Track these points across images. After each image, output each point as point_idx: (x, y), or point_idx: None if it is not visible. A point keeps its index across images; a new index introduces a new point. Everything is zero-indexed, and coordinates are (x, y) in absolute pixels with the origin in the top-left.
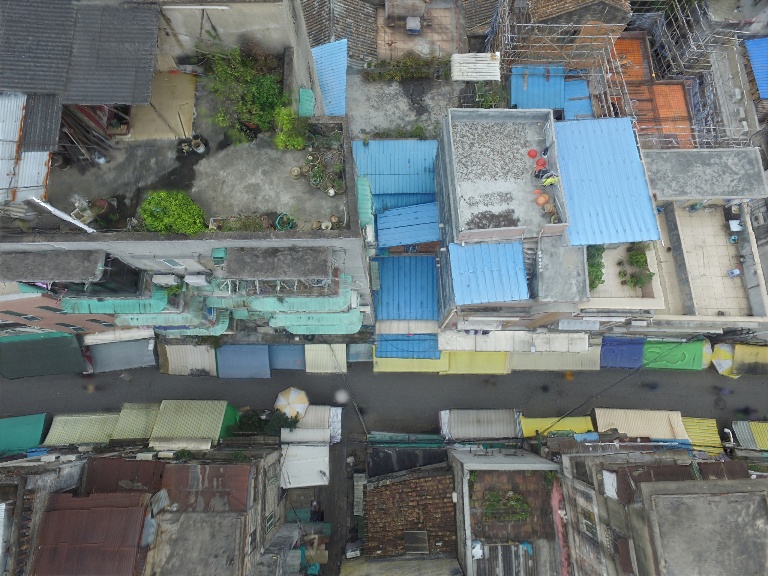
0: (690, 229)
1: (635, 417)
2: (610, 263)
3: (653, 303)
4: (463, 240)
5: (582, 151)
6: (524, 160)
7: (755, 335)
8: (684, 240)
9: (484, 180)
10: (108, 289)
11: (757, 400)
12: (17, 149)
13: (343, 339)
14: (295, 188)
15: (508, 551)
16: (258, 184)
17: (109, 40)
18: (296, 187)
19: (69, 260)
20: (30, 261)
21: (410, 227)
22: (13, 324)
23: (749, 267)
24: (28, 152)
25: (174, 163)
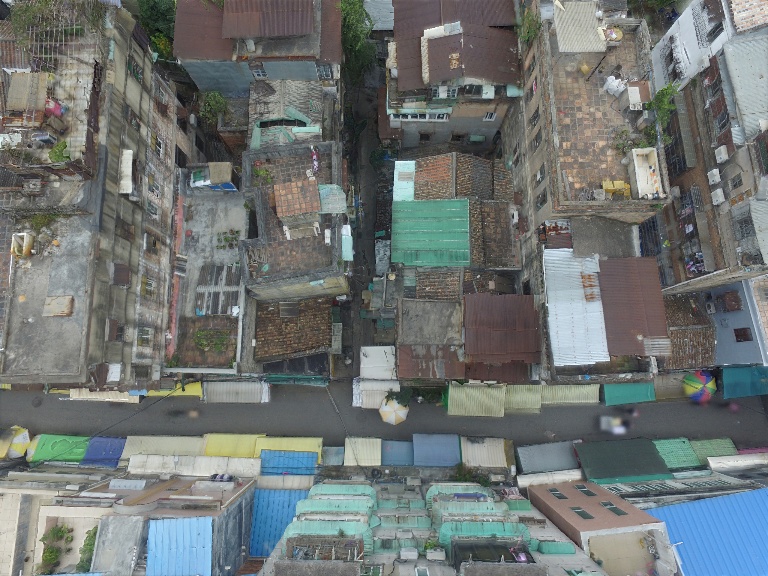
0: None
1: (107, 395)
2: (78, 550)
3: (49, 512)
4: None
5: None
6: None
7: None
8: None
9: None
10: None
11: (6, 405)
12: None
13: (346, 470)
14: None
15: (214, 311)
16: None
17: None
18: None
19: None
20: None
21: None
22: (633, 496)
23: None
24: None
25: None
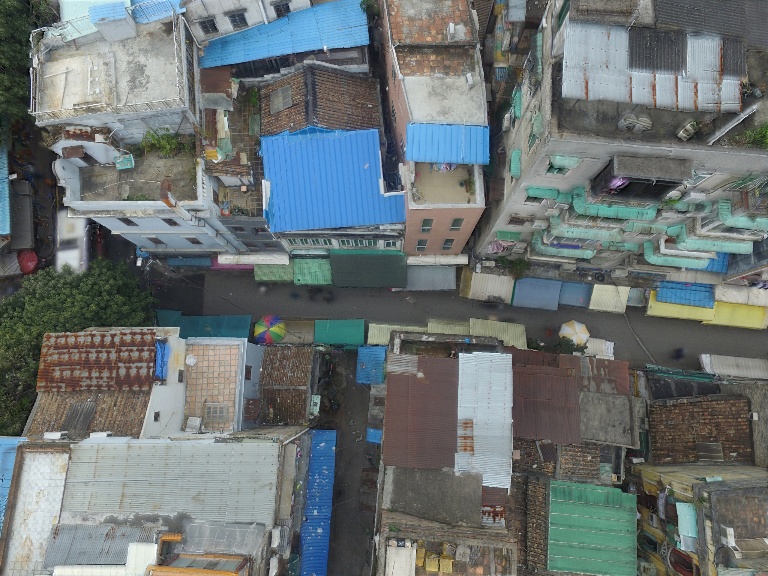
0: None
1: None
2: None
3: None
4: None
5: None
6: None
7: None
8: None
9: None
10: None
11: None
12: (721, 77)
13: (629, 283)
14: None
15: None
16: None
17: (766, 7)
18: None
19: (670, 165)
20: (641, 163)
21: None
22: (388, 236)
23: None
24: (725, 80)
25: None
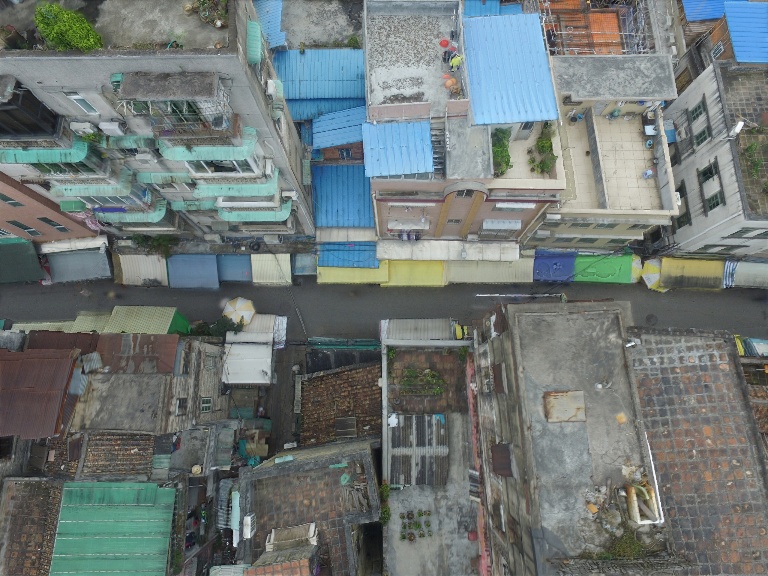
0: (609, 135)
1: None
2: (521, 153)
3: (555, 184)
4: (375, 119)
5: (492, 43)
6: (436, 49)
7: (679, 247)
8: (603, 145)
9: (398, 67)
10: (25, 127)
11: (687, 317)
12: None
13: (287, 249)
14: (188, 24)
15: (422, 420)
16: (155, 21)
17: None
18: (189, 23)
19: None
20: None
21: (342, 129)
22: None
23: (661, 168)
24: None
25: (81, 4)
